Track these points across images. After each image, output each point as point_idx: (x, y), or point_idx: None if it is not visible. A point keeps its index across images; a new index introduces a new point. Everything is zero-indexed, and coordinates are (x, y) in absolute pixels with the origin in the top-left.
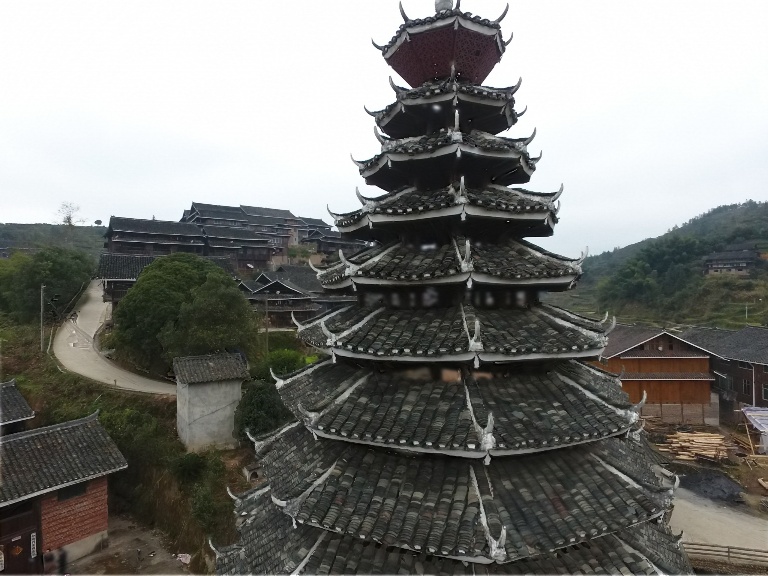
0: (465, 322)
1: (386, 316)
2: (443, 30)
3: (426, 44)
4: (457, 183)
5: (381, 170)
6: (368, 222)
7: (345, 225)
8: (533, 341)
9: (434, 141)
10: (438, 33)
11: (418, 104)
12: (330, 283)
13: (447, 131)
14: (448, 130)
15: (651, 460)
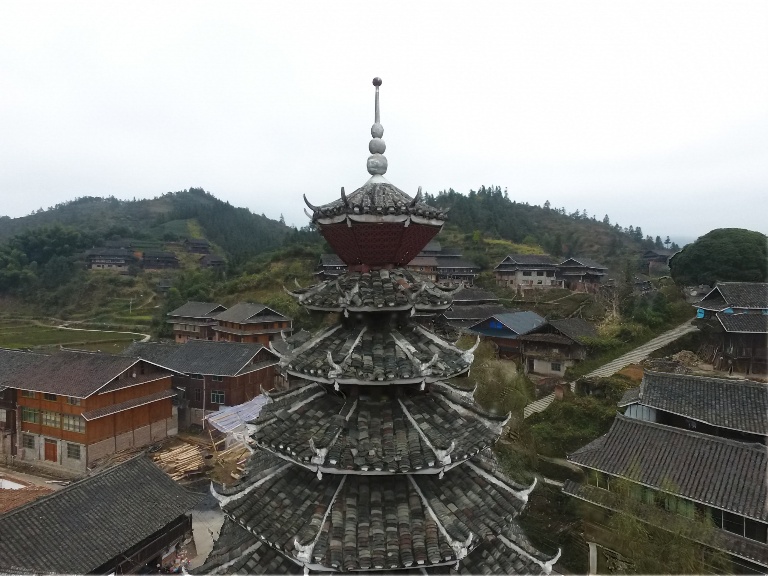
0: (513, 545)
1: (448, 574)
2: (432, 228)
3: (414, 234)
4: (455, 398)
5: (391, 385)
6: (438, 473)
7: (365, 470)
8: (513, 529)
9: (430, 350)
10: (428, 229)
11: (424, 309)
12: (383, 568)
13: (418, 330)
14: (425, 332)
15: (191, 503)
